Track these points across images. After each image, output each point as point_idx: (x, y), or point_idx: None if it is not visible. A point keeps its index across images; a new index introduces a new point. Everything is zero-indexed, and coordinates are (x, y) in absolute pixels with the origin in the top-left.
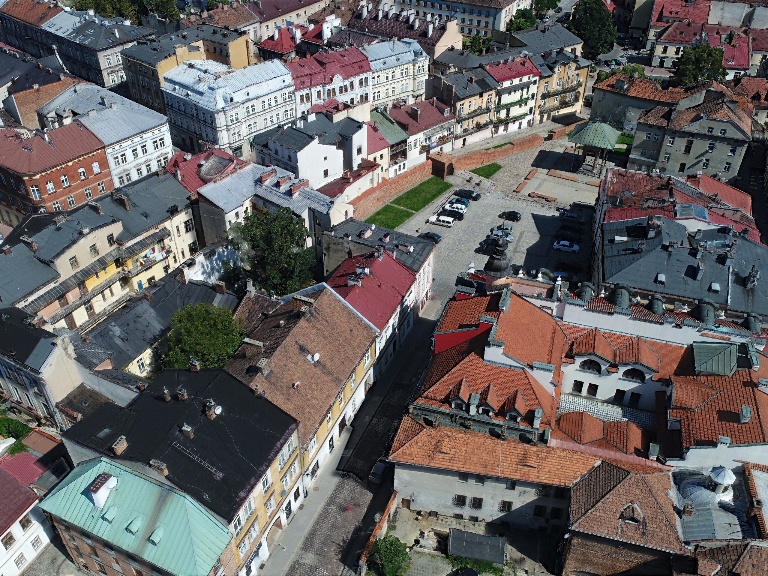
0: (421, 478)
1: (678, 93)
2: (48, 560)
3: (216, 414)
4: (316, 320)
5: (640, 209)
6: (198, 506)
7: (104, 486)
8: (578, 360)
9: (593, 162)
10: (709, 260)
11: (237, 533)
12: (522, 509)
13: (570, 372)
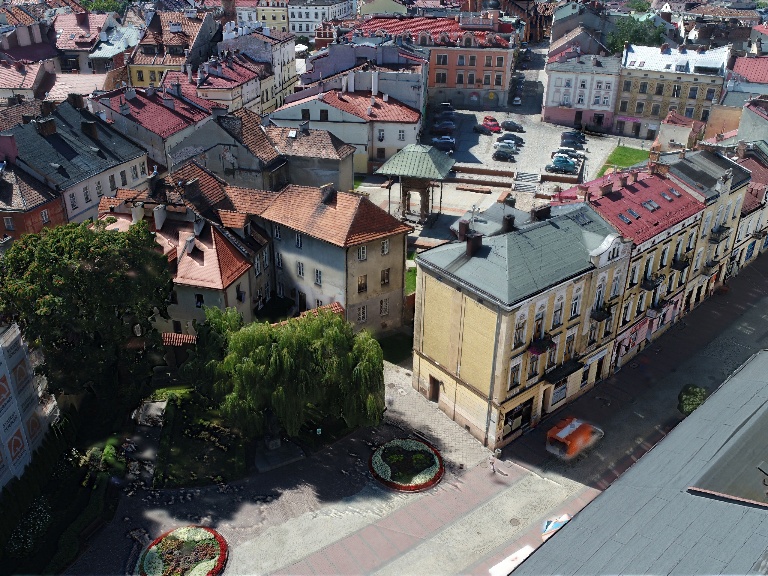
0: None
1: (249, 189)
2: None
3: None
4: None
5: None
6: None
7: None
8: None
9: None
10: None
11: None
12: None
13: None
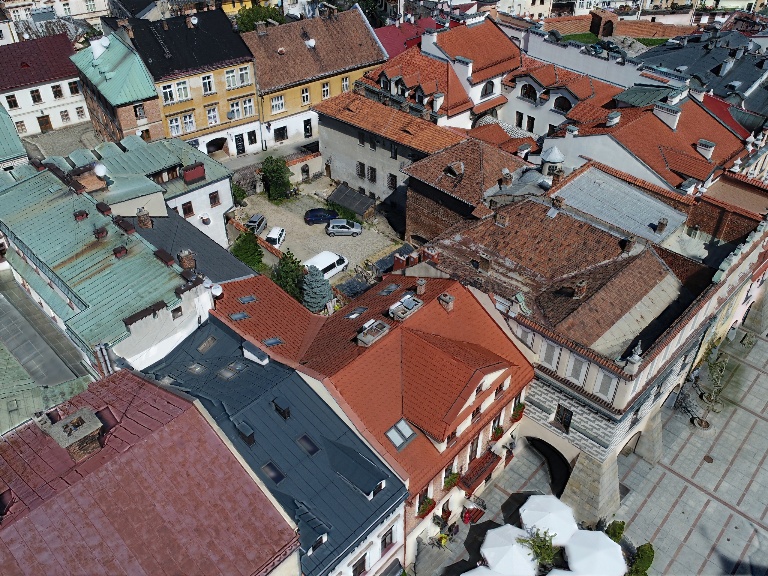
0: (335, 138)
1: None
2: (84, 128)
3: (193, 24)
4: (332, 24)
5: None
6: (142, 64)
7: (99, 41)
8: (519, 84)
9: None
10: (748, 62)
11: (168, 104)
12: (404, 187)
13: (512, 100)
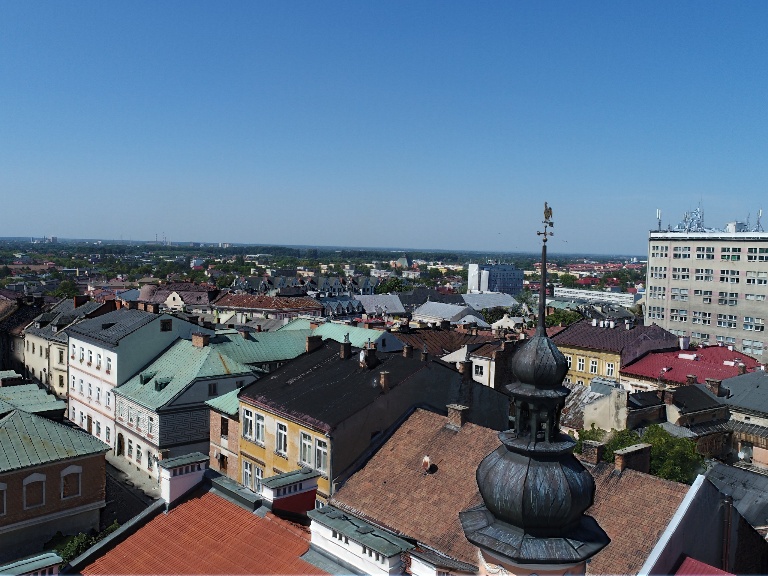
0: None
1: None
2: None
3: None
4: None
5: None
6: None
7: None
8: None
9: None
10: None
11: (247, 437)
12: None
13: None
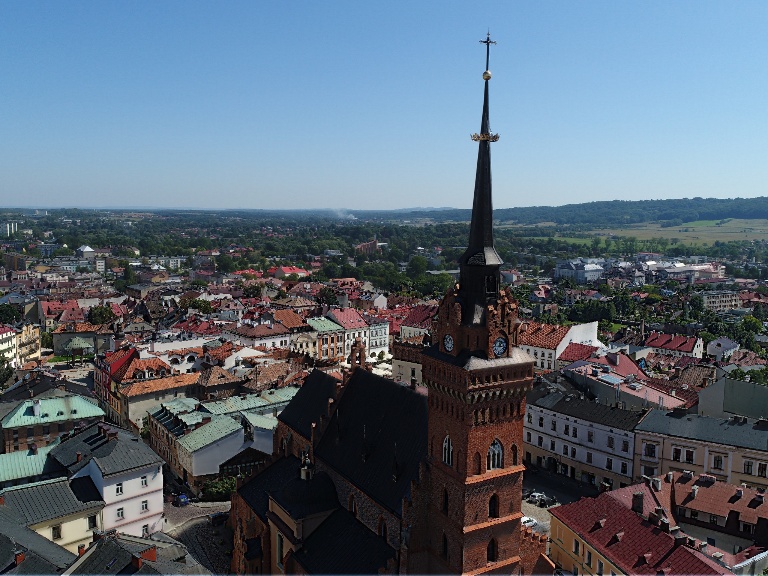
0: (140, 406)
1: None
2: None
3: None
4: None
5: (142, 338)
6: (84, 398)
7: (39, 403)
8: None
9: (78, 364)
10: None
11: None
12: None
13: None
